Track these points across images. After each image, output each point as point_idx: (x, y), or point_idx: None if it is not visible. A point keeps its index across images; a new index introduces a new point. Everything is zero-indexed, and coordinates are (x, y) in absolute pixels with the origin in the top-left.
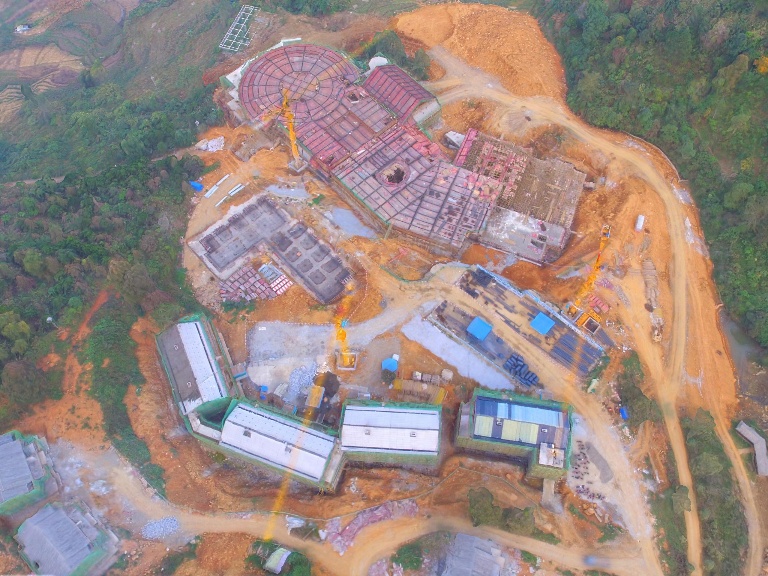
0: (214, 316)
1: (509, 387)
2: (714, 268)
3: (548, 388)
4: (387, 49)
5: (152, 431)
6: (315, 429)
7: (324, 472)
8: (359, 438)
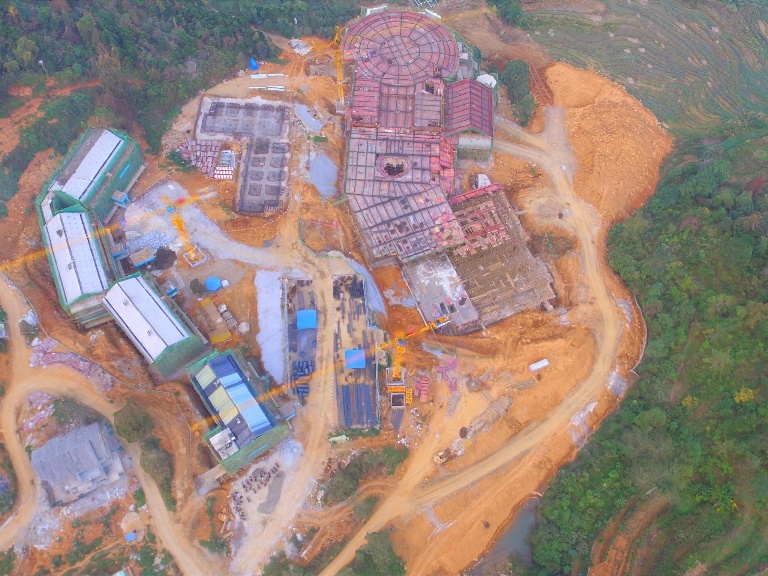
0: (157, 154)
1: (278, 379)
2: (571, 462)
3: (307, 408)
4: (510, 77)
5: (31, 186)
6: (106, 272)
7: (75, 302)
8: (118, 302)
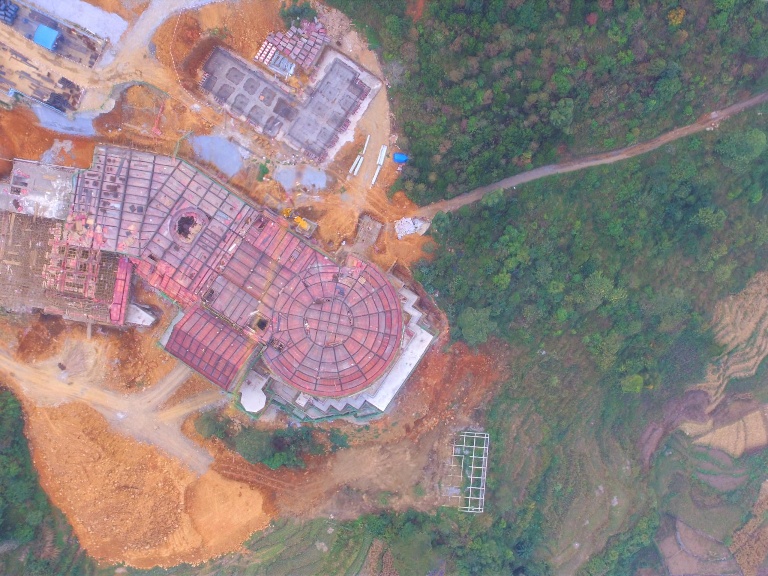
0: None
1: None
2: None
3: None
4: None
5: None
6: None
7: None
8: None
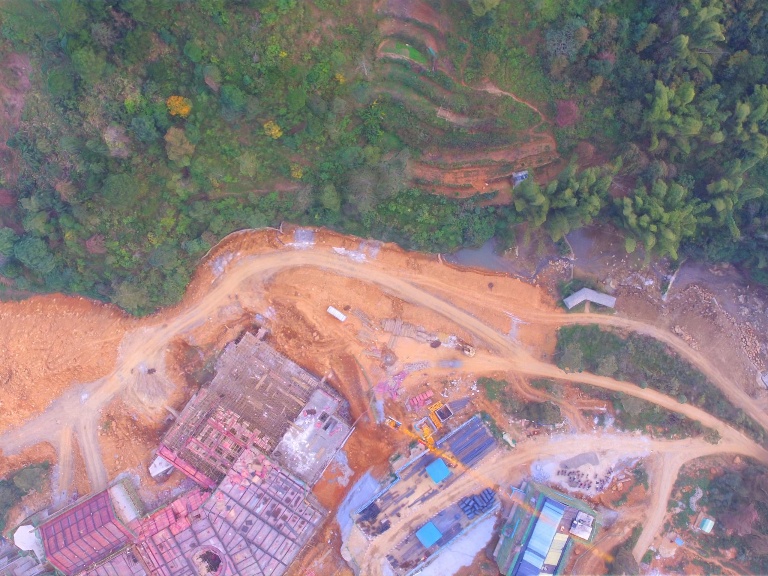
0: None
1: (493, 522)
2: (398, 245)
3: (500, 481)
4: None
5: None
6: None
7: None
8: None
